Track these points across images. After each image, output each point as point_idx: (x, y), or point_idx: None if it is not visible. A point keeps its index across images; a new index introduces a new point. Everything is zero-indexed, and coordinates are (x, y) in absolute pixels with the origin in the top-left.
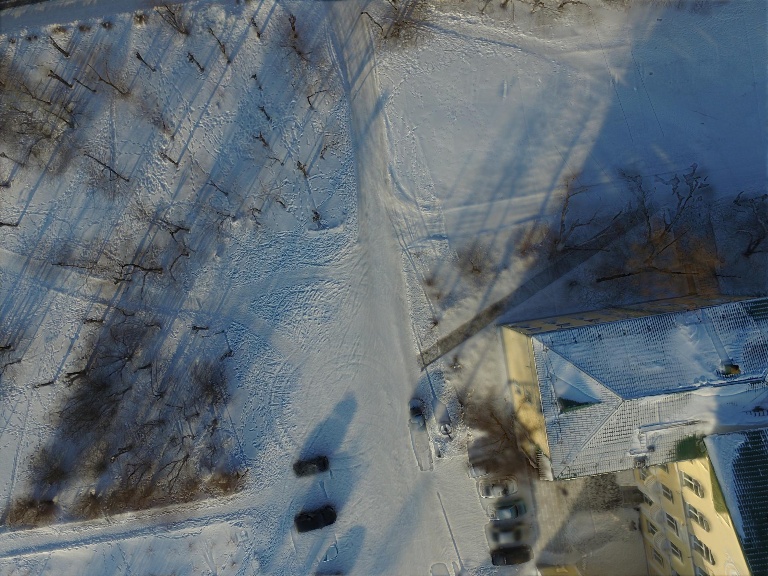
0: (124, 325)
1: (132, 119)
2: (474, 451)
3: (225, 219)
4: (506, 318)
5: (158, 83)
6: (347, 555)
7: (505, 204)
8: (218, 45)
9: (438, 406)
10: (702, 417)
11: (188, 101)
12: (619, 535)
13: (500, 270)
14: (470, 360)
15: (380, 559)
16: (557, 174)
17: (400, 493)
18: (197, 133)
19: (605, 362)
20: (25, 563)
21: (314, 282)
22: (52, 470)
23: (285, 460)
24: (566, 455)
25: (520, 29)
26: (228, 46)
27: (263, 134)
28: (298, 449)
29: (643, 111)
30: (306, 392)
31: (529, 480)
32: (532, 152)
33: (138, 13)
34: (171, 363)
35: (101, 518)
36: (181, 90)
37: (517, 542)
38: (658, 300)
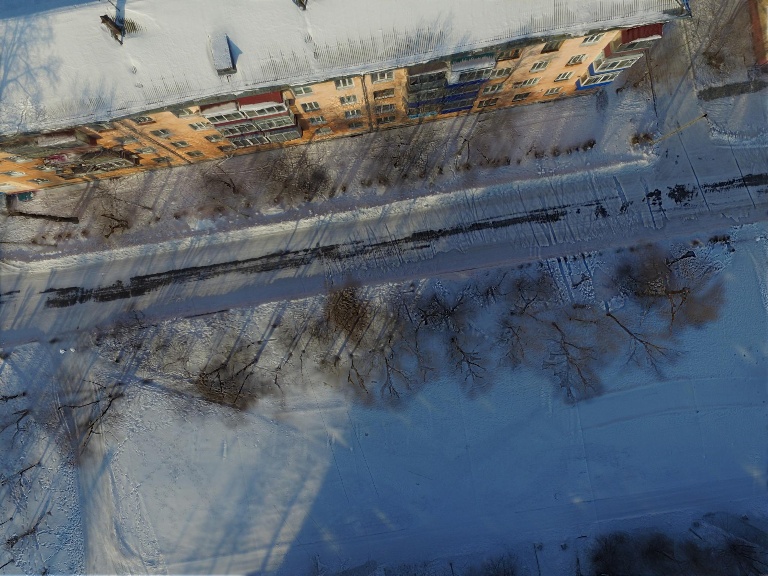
0: None
1: None
2: None
3: None
4: None
5: None
6: None
7: (227, 560)
8: None
9: None
10: None
11: None
12: None
13: None
14: None
15: None
16: (277, 532)
17: None
18: None
19: None
20: None
21: None
22: None
23: None
24: None
25: (239, 389)
26: None
27: None
28: None
29: (359, 472)
30: None
31: None
32: (251, 511)
33: None
34: None
35: None
36: None
37: None
38: None
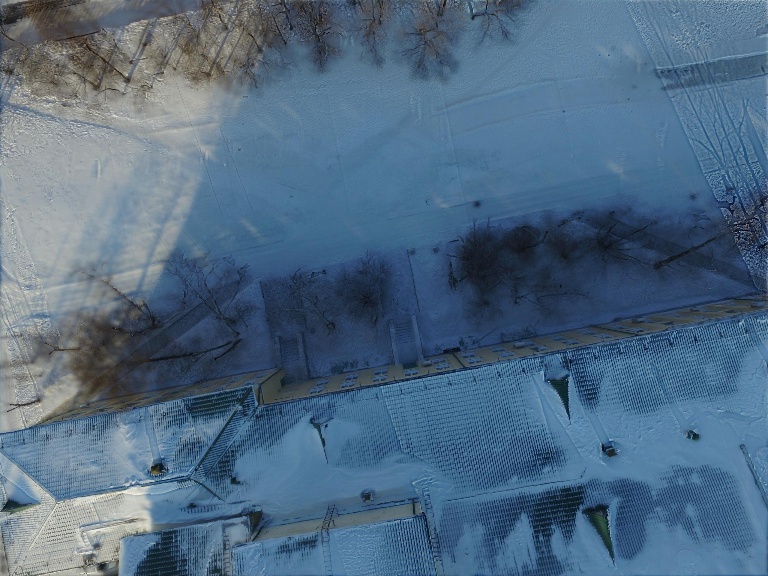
0: None
1: None
2: None
3: None
4: None
5: None
6: None
7: None
8: None
9: None
10: (139, 515)
11: None
12: None
13: (99, 347)
14: None
15: None
16: (153, 250)
17: None
18: None
19: (47, 463)
20: None
21: None
22: None
23: None
24: (18, 555)
25: (112, 110)
26: None
27: None
28: None
29: (232, 186)
30: None
31: None
32: (127, 230)
33: None
34: None
35: None
36: None
37: None
38: None
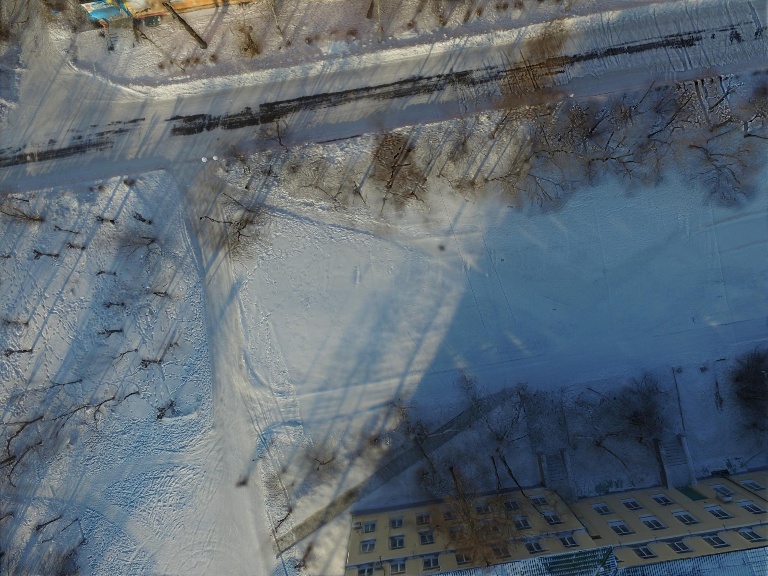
0: None
1: None
2: None
3: (79, 406)
4: (360, 505)
5: (12, 269)
6: None
7: (359, 390)
8: (73, 231)
9: None
10: None
11: (42, 288)
12: None
13: (354, 457)
14: (324, 548)
15: None
16: (411, 360)
17: None
18: (51, 320)
19: None
20: None
21: (169, 468)
22: None
23: None
24: None
25: (373, 216)
26: (83, 232)
27: (117, 320)
28: None
29: (495, 298)
30: None
31: None
32: (385, 338)
33: None
34: (24, 551)
35: None
36: (35, 277)
37: None
38: (508, 491)
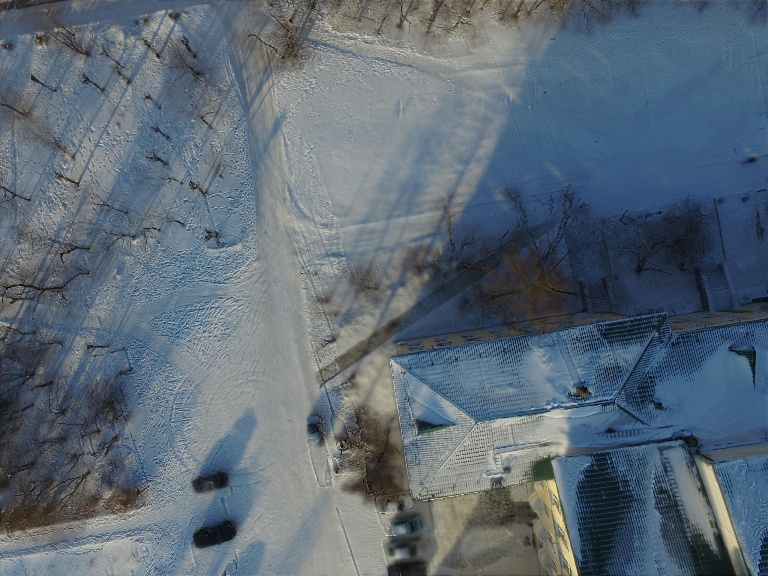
0: (26, 343)
1: (33, 139)
2: (372, 467)
3: (125, 238)
4: (403, 335)
5: (59, 103)
6: (247, 570)
7: (402, 222)
8: (118, 65)
9: (336, 422)
10: (555, 439)
11: (88, 121)
12: (513, 550)
13: (397, 287)
14: (367, 377)
15: (280, 574)
16: (453, 192)
17: (300, 509)
18: (97, 153)
19: (460, 384)
20: None
21: (214, 300)
22: None
23: (186, 476)
24: (424, 476)
25: (416, 49)
26: (128, 66)
27: (163, 153)
28: (199, 465)
29: (537, 129)
30: (206, 409)
31: None
32: (428, 170)
33: (39, 34)
34: (72, 380)
35: (3, 534)
36: (81, 110)
37: (413, 557)
38: (551, 317)
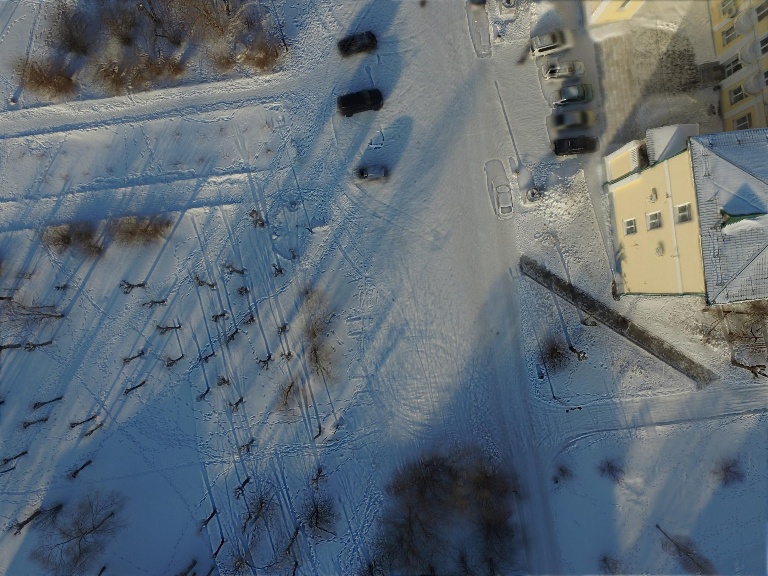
0: None
1: None
2: (537, 34)
3: None
4: None
5: None
6: (393, 148)
7: None
8: None
9: None
10: None
11: None
12: (696, 119)
13: None
14: None
15: (429, 153)
16: None
17: (454, 81)
18: None
19: None
20: (38, 146)
21: None
22: (72, 37)
23: (328, 42)
24: None
25: None
26: None
27: None
28: (343, 30)
29: None
30: None
31: (597, 67)
32: None
33: None
34: None
35: (124, 95)
36: None
37: (583, 127)
38: None
